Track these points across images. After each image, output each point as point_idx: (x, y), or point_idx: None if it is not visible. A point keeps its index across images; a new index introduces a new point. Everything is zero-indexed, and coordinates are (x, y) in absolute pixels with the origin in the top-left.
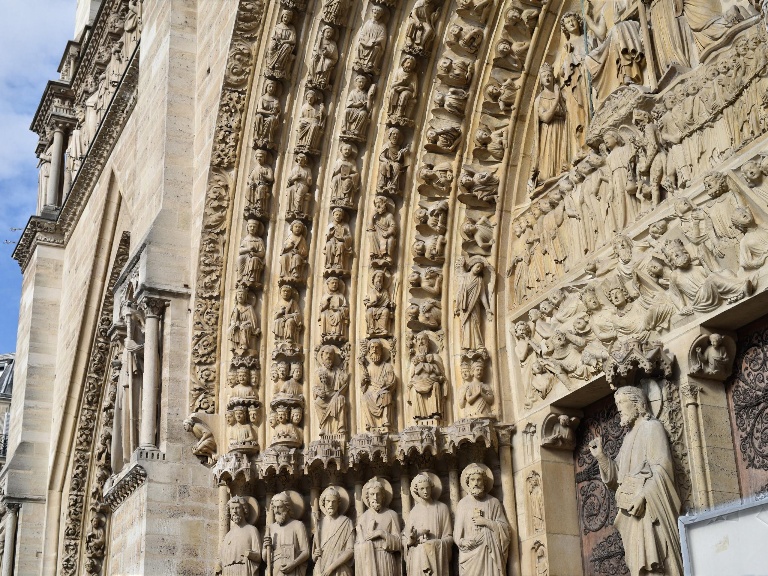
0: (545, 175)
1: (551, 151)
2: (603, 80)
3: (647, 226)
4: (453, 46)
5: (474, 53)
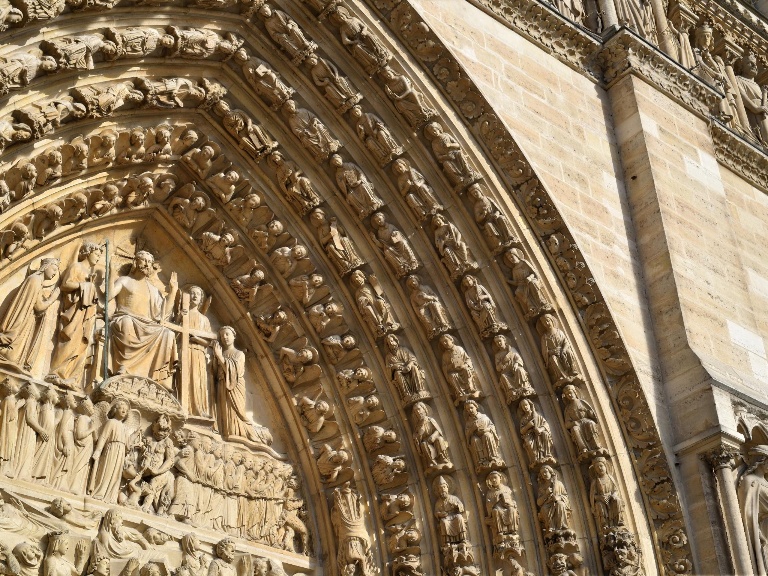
0: (16, 357)
1: (27, 339)
2: (136, 355)
3: (138, 521)
4: (40, 161)
5: (38, 184)
